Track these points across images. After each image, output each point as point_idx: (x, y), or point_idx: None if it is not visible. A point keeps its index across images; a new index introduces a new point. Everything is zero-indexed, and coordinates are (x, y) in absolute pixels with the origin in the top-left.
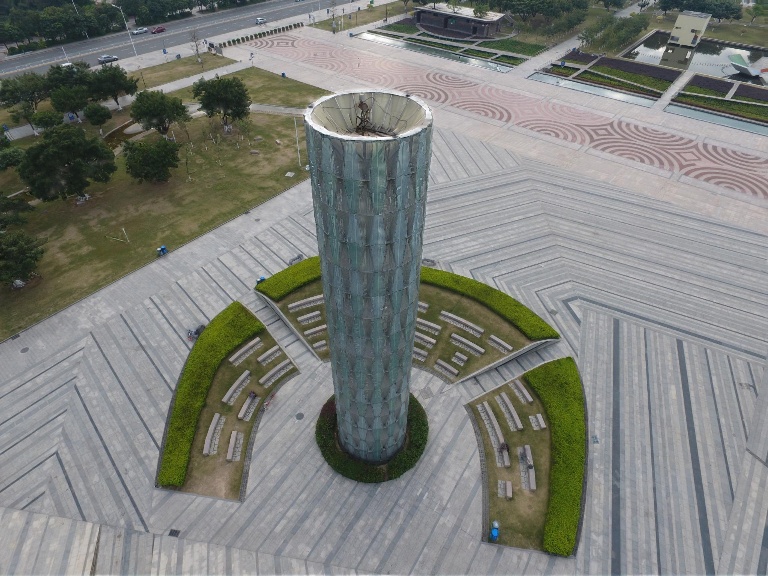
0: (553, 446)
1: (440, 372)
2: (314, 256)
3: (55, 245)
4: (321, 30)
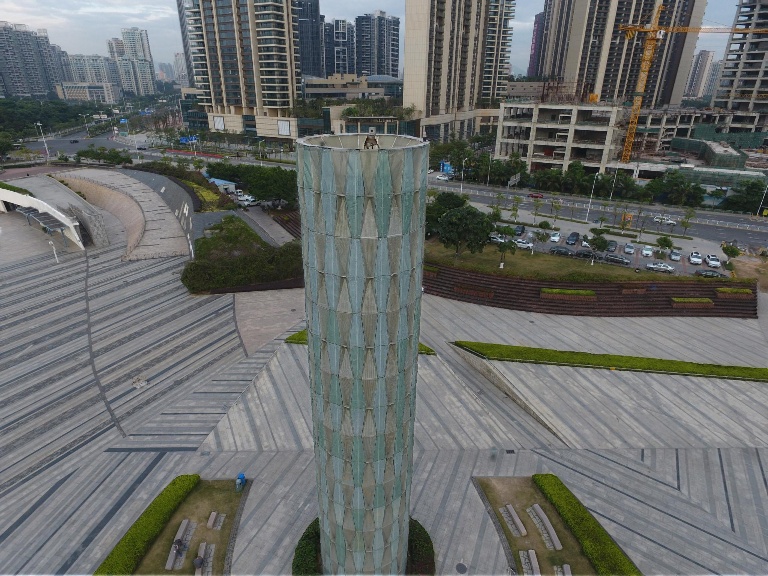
0: (138, 560)
1: None
2: None
3: None
4: None
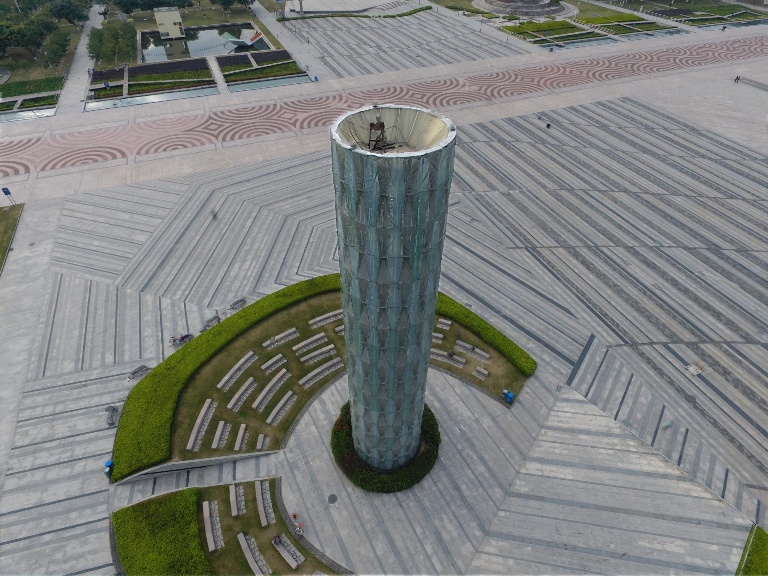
0: (468, 326)
1: None
2: (128, 394)
3: None
4: None
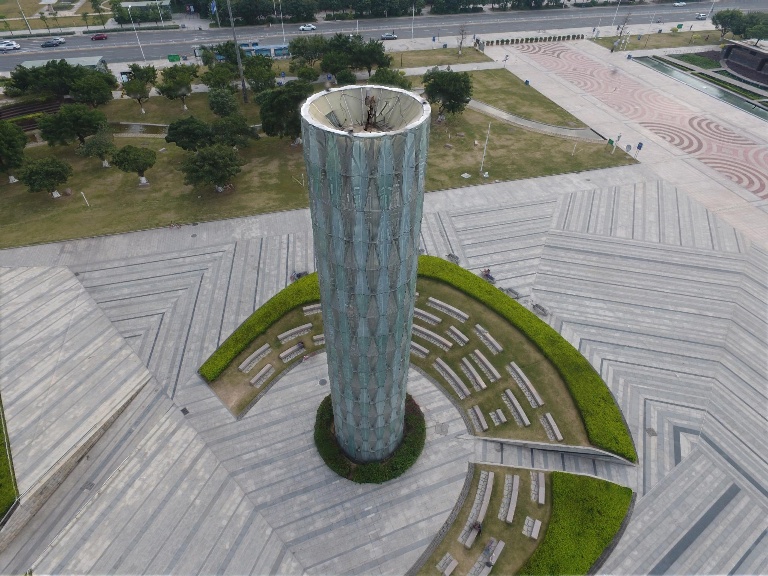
0: (528, 562)
1: (470, 418)
2: (433, 256)
3: (258, 170)
4: (599, 46)
